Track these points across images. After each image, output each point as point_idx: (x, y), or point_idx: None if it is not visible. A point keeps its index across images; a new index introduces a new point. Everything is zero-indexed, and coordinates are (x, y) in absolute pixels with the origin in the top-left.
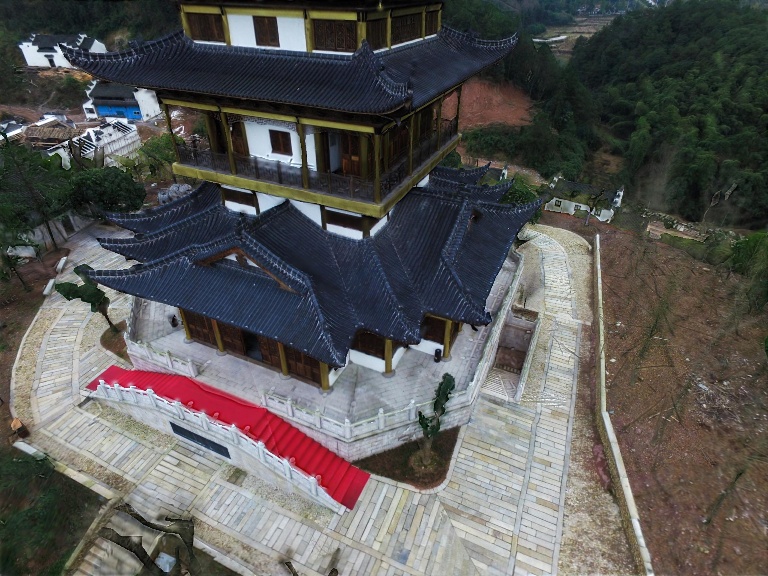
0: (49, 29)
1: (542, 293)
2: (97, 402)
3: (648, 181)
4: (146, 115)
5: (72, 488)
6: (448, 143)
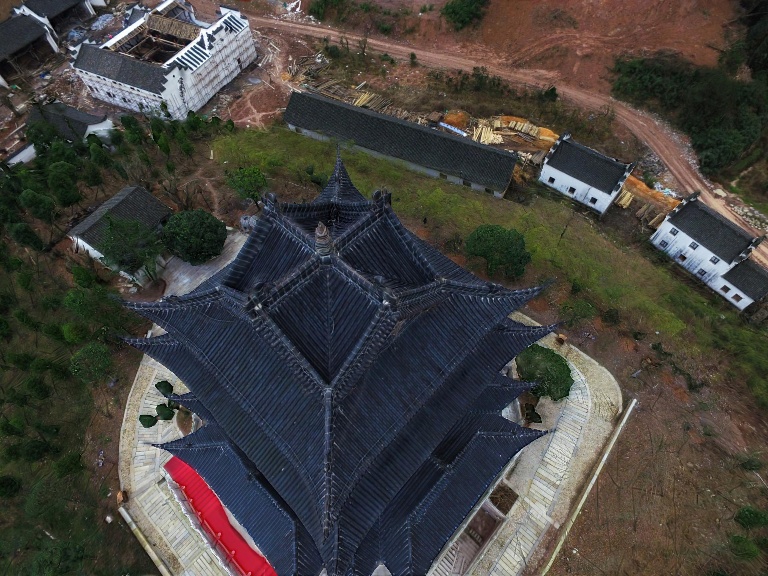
0: None
1: (535, 470)
2: None
3: None
4: None
5: (148, 565)
6: None
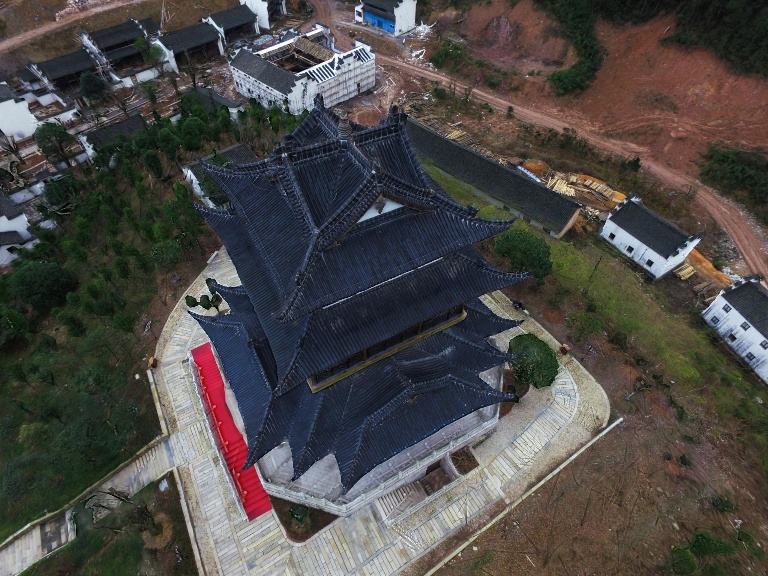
0: None
1: (502, 449)
2: None
3: None
4: (399, 30)
5: (153, 416)
6: (439, 325)
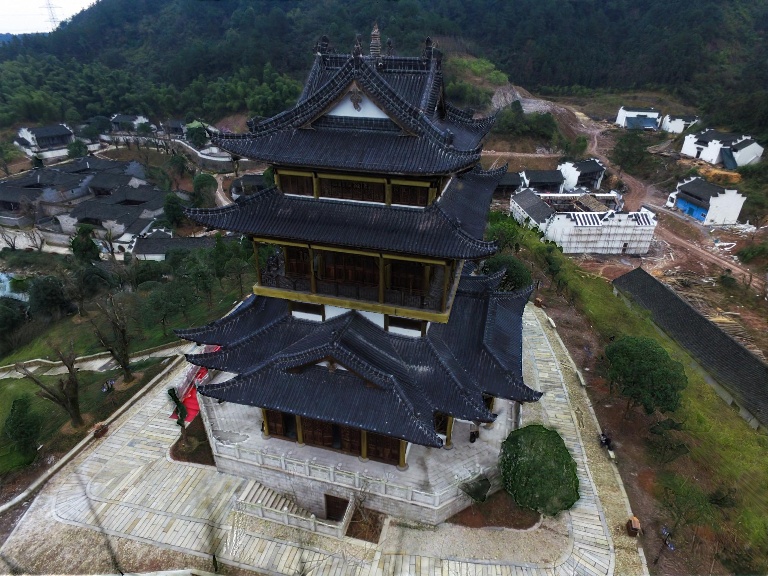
0: (732, 126)
1: (422, 553)
2: None
3: None
4: (711, 220)
5: None
6: (408, 307)
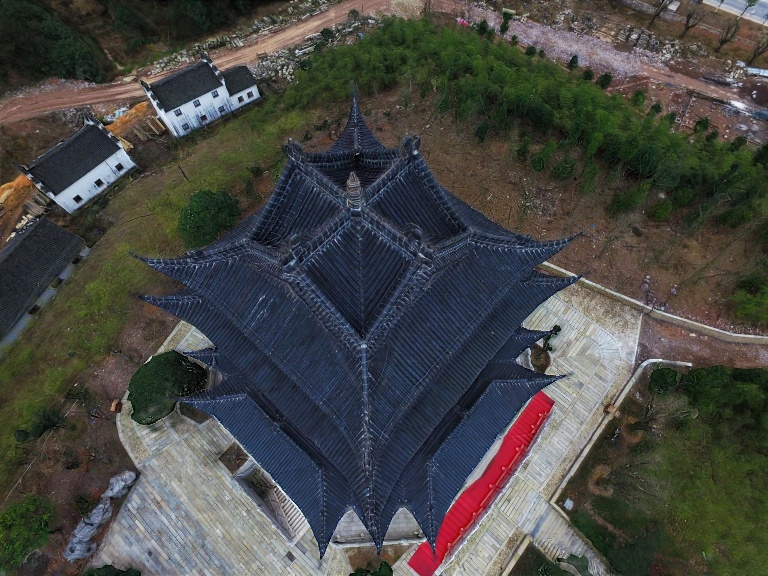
0: None
1: None
2: (445, 569)
3: (137, 0)
4: None
5: (520, 567)
6: None
